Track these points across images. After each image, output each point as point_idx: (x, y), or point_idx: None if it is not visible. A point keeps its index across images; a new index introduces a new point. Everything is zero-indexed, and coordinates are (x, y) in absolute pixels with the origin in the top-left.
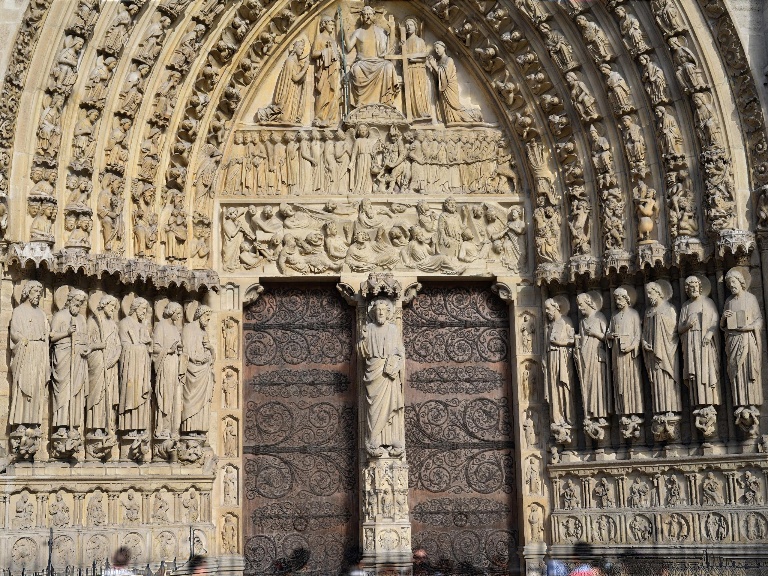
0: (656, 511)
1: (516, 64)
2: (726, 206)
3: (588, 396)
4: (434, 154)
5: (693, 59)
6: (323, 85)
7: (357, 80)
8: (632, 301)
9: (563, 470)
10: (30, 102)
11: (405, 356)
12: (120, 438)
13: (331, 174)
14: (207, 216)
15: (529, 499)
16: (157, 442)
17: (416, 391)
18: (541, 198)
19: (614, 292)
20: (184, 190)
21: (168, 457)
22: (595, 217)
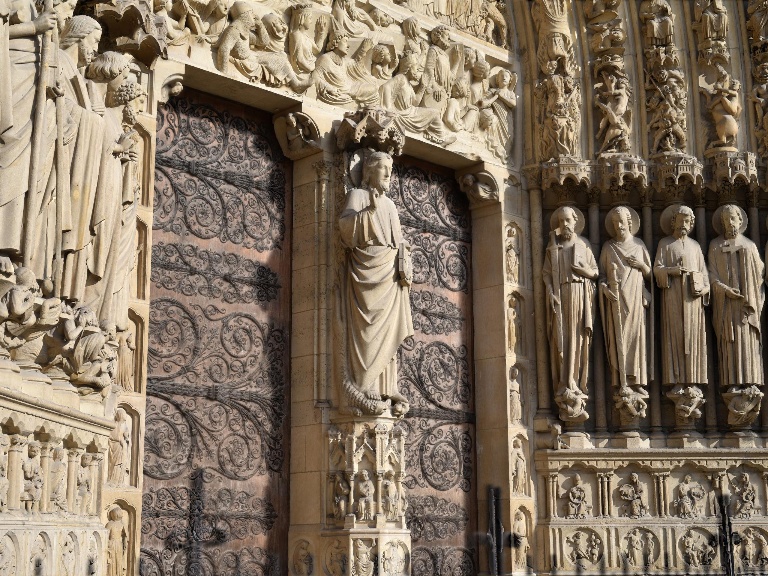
0: None
1: None
2: None
3: (628, 353)
4: None
5: None
6: None
7: None
8: None
9: (572, 459)
10: None
11: None
12: None
13: None
14: None
15: (516, 501)
16: None
17: None
18: (555, 62)
19: (681, 210)
20: None
21: None
22: (636, 105)
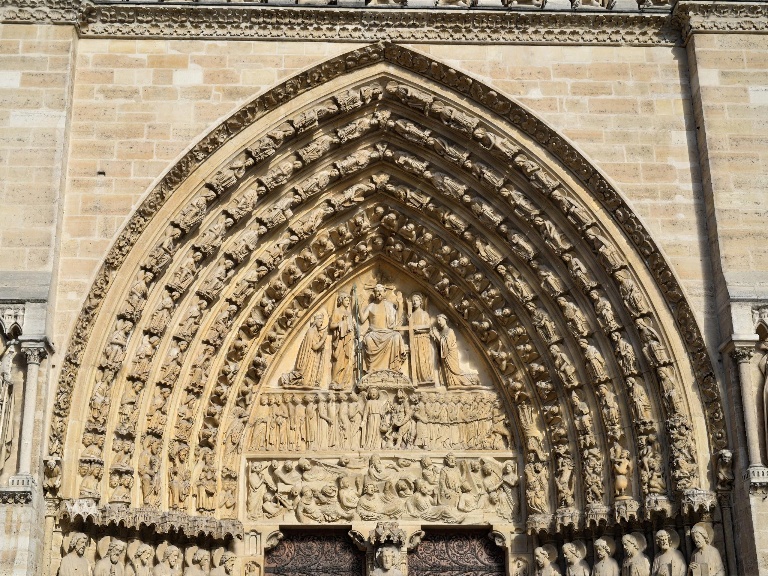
0: None
1: (508, 336)
2: (689, 468)
3: None
4: (436, 414)
5: (657, 337)
6: (339, 353)
7: (369, 349)
8: (612, 551)
9: None
10: (85, 377)
11: None
12: None
13: (345, 432)
14: (234, 470)
15: None
16: None
17: None
18: (531, 455)
19: (595, 543)
20: (215, 448)
21: None
22: (578, 473)
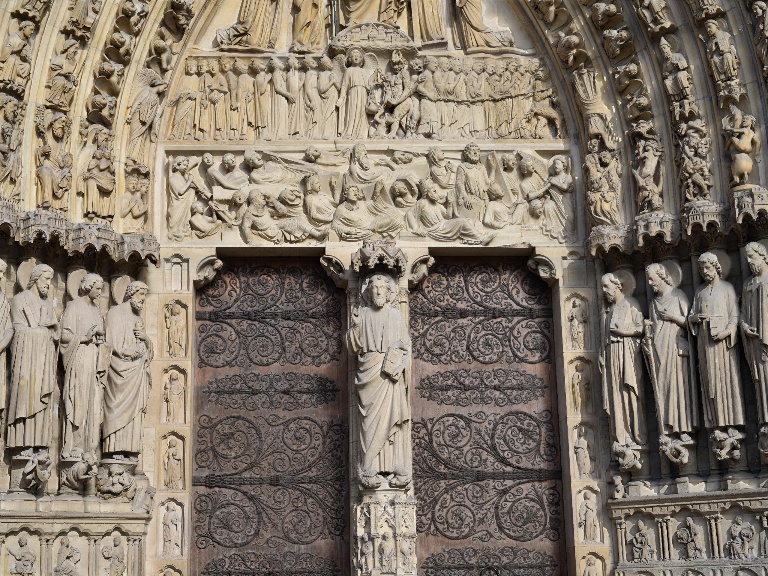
0: (767, 563)
1: None
2: None
3: (665, 403)
4: (450, 87)
5: None
6: None
7: None
8: (724, 271)
9: (630, 507)
10: None
11: (413, 355)
12: (10, 459)
13: (313, 113)
14: (146, 165)
15: (583, 548)
16: (65, 466)
17: (427, 402)
18: (594, 141)
19: (699, 258)
20: (113, 128)
21: (83, 488)
22: (669, 161)
